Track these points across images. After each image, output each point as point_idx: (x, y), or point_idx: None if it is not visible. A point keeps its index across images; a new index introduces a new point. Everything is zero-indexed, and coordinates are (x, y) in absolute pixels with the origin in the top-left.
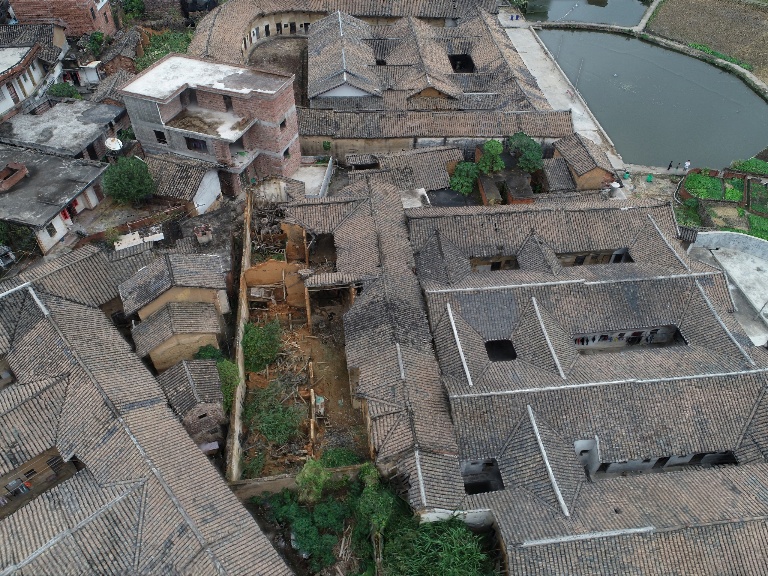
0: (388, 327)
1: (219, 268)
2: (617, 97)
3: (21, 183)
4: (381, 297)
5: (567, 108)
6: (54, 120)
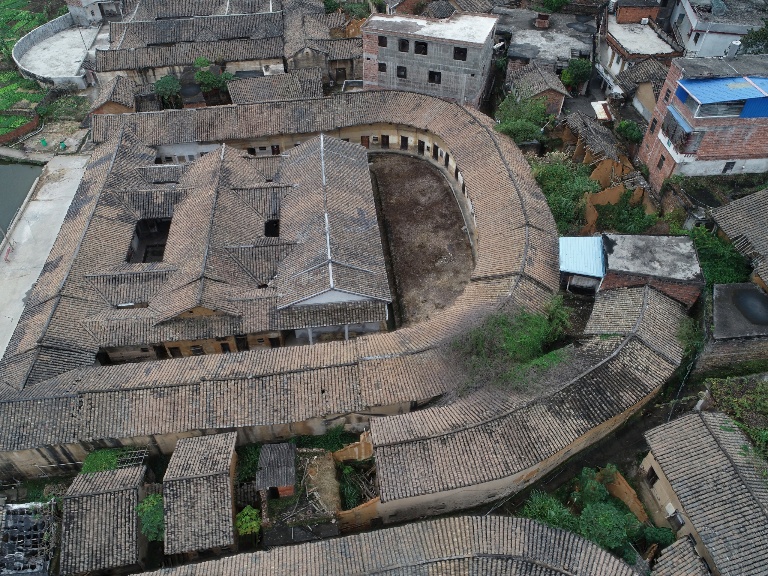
0: (303, 1)
1: (389, 3)
2: None
3: (533, 22)
4: (305, 8)
5: (35, 233)
6: (555, 45)
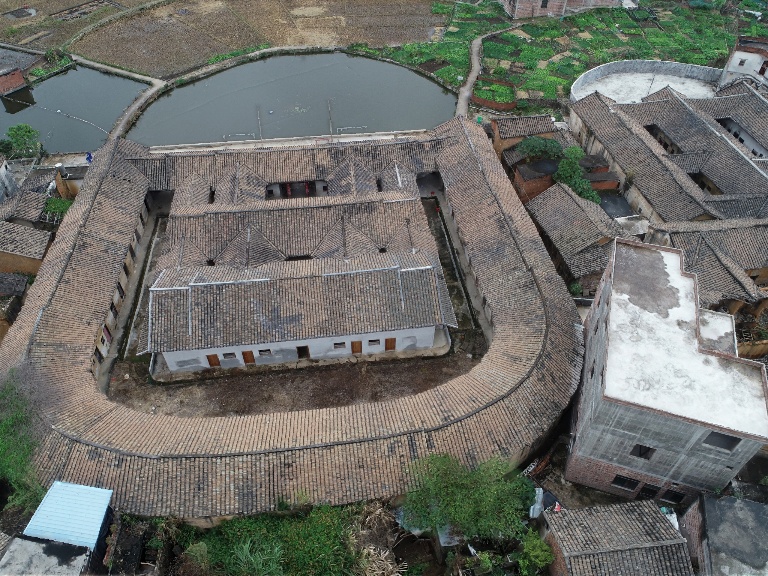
0: None
1: None
2: (321, 118)
3: None
4: None
5: None
6: None
